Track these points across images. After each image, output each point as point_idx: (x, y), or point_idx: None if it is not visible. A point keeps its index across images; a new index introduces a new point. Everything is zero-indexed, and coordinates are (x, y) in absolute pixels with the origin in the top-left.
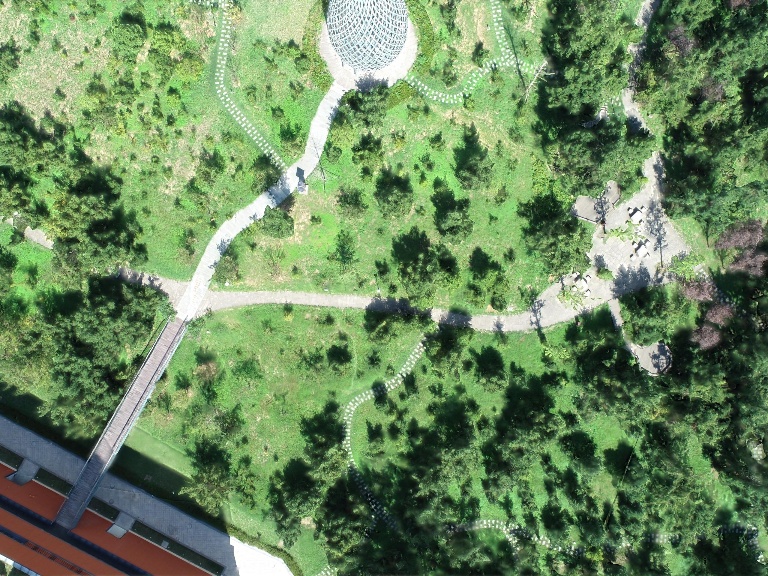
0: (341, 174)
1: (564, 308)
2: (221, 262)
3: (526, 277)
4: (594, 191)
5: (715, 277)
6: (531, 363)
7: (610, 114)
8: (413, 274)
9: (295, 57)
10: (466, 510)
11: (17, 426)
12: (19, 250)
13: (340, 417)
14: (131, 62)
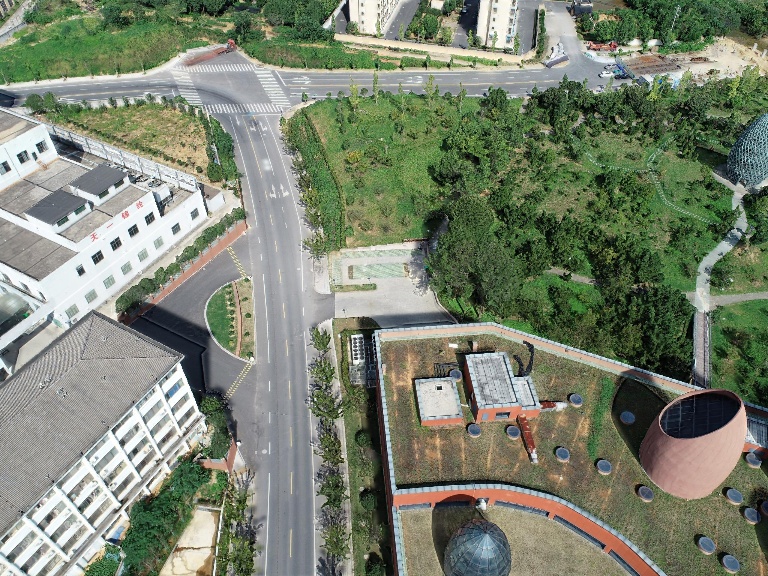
0: None
1: None
2: (722, 268)
3: None
4: None
5: None
6: None
7: None
8: None
9: (707, 183)
10: None
11: None
12: None
13: None
14: None
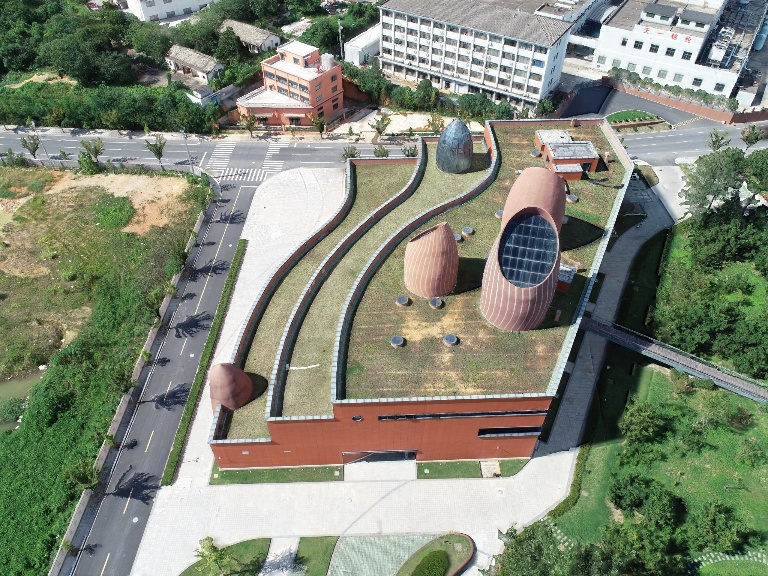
0: None
1: None
2: None
3: None
4: None
5: None
6: None
7: None
8: None
9: None
10: None
11: (618, 300)
12: (758, 296)
13: (749, 547)
14: None
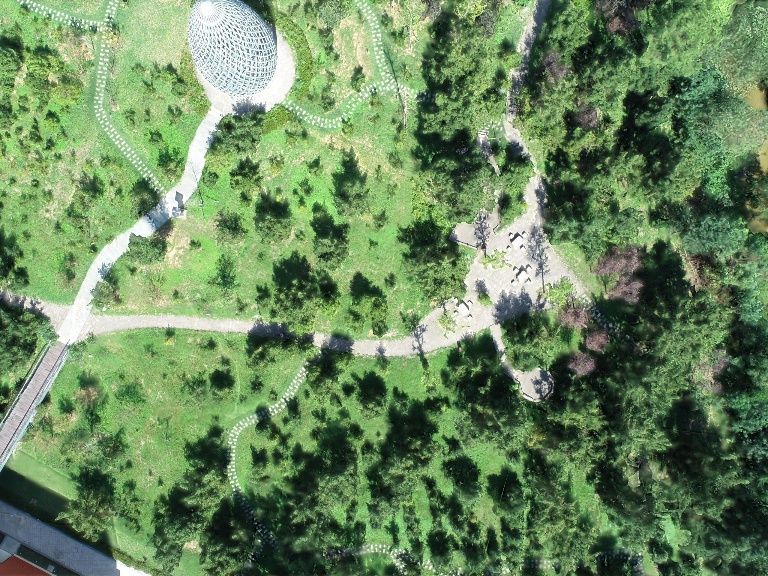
0: (220, 199)
1: (446, 333)
2: (98, 287)
3: (408, 302)
4: (461, 219)
5: (598, 302)
6: (414, 388)
7: (491, 139)
8: (286, 300)
9: (171, 81)
10: (352, 535)
11: None
12: None
13: (224, 441)
14: (7, 86)
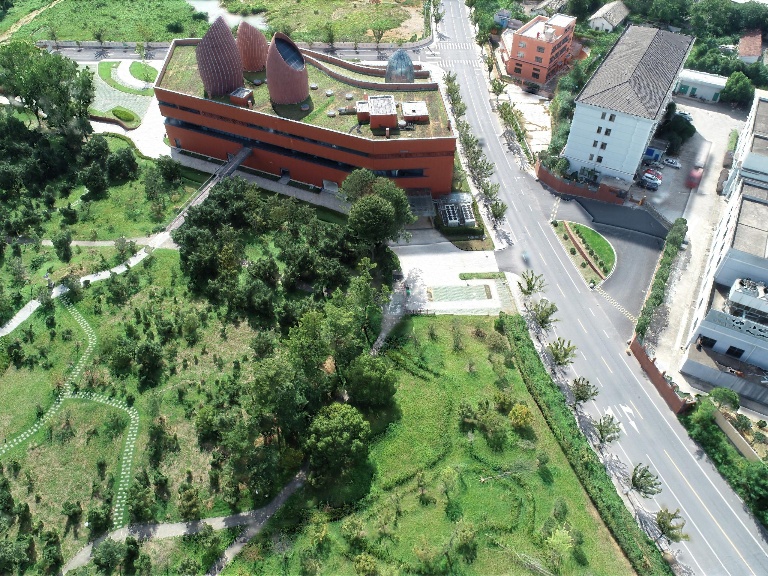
0: None
1: None
2: (122, 245)
3: None
4: None
5: None
6: None
7: None
8: None
9: None
10: None
11: None
12: None
13: None
14: None
